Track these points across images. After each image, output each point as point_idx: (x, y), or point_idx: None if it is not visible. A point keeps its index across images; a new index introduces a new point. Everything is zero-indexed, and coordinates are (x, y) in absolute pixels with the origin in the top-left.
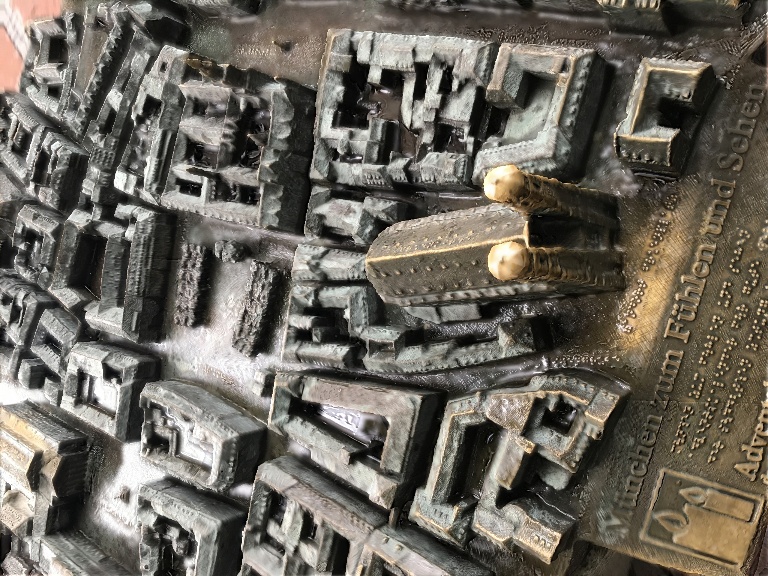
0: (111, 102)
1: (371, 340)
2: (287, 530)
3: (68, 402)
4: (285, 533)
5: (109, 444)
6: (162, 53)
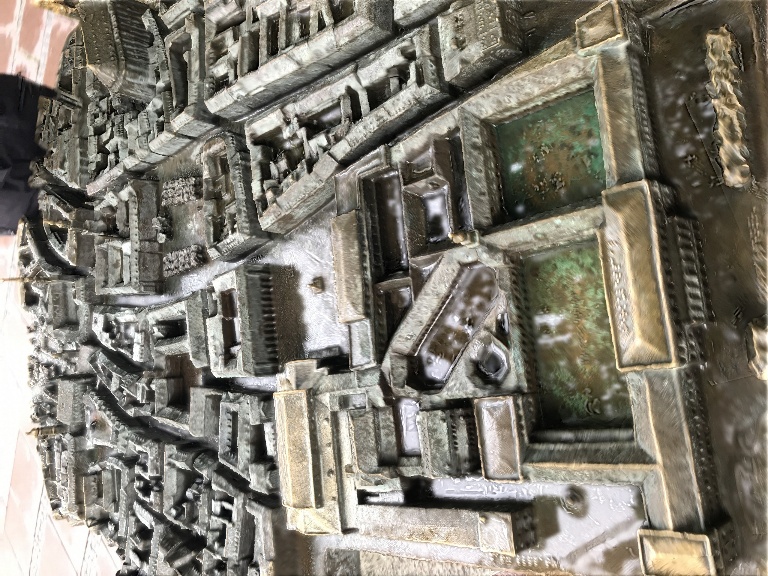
0: (114, 388)
1: (156, 83)
2: (223, 64)
3: (237, 358)
4: (225, 64)
5: (297, 334)
6: (92, 326)
